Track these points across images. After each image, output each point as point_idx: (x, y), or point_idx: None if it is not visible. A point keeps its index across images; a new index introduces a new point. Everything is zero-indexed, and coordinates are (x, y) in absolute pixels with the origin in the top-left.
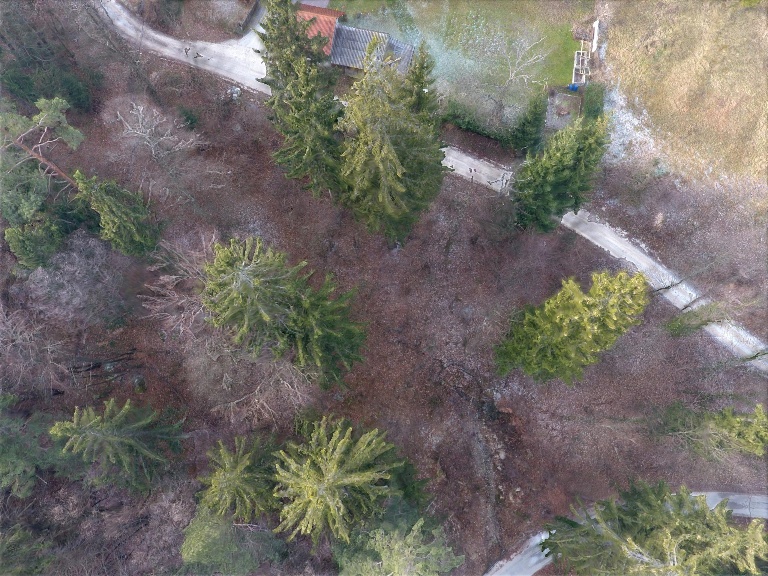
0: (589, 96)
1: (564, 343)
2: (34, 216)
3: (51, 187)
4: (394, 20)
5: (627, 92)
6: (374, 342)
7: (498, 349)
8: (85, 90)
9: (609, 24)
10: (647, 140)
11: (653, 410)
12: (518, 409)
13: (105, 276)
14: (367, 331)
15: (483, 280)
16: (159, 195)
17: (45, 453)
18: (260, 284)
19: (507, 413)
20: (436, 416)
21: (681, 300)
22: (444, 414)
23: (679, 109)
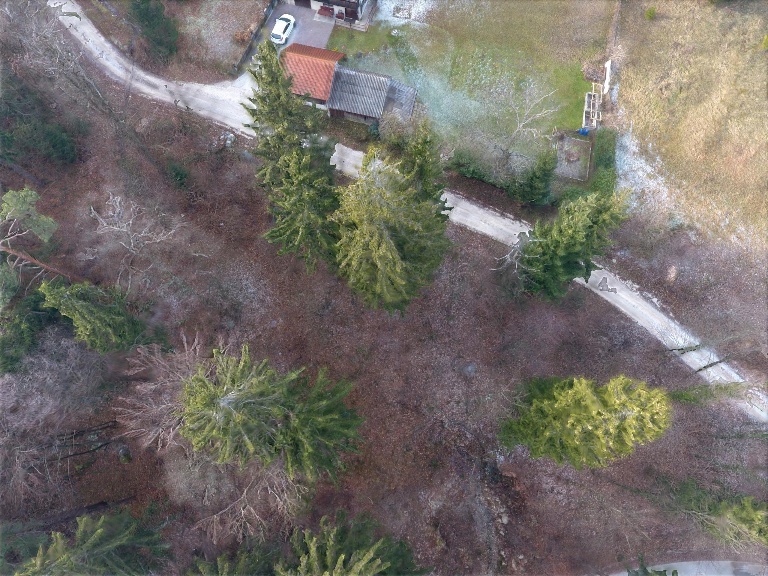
0: (600, 143)
1: (574, 440)
2: (2, 314)
3: (22, 278)
4: (396, 59)
5: (640, 137)
6: (372, 403)
7: (502, 423)
8: (70, 141)
9: (622, 64)
10: (660, 189)
11: (665, 483)
12: (522, 472)
13: (79, 378)
14: (365, 392)
15: (487, 336)
16: (147, 251)
17: (13, 570)
18: (244, 405)
19: (510, 476)
20: (436, 478)
21: (694, 359)
22: (445, 476)
23: (694, 156)
